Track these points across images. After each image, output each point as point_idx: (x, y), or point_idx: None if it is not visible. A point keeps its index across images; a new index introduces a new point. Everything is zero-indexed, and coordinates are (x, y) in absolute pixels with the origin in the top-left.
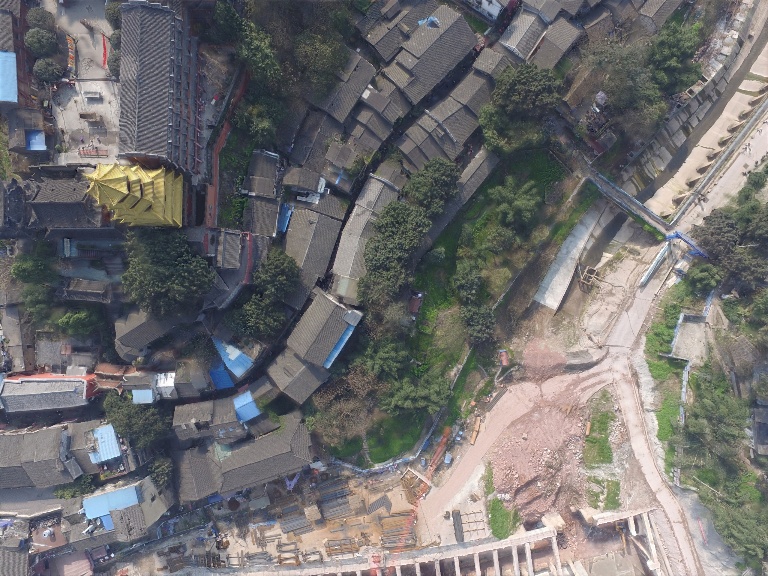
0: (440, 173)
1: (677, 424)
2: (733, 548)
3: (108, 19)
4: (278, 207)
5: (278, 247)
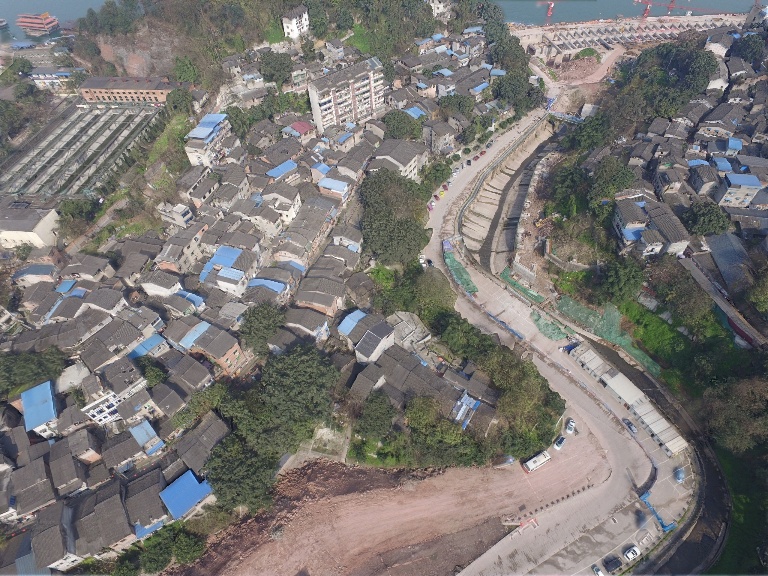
0: None
1: None
2: None
3: None
4: (767, 69)
5: (756, 67)
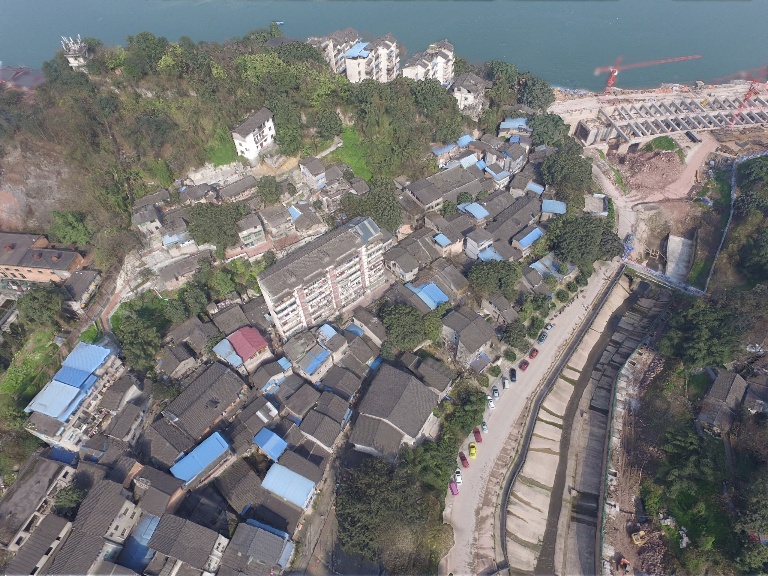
0: None
1: None
2: None
3: None
4: None
5: None
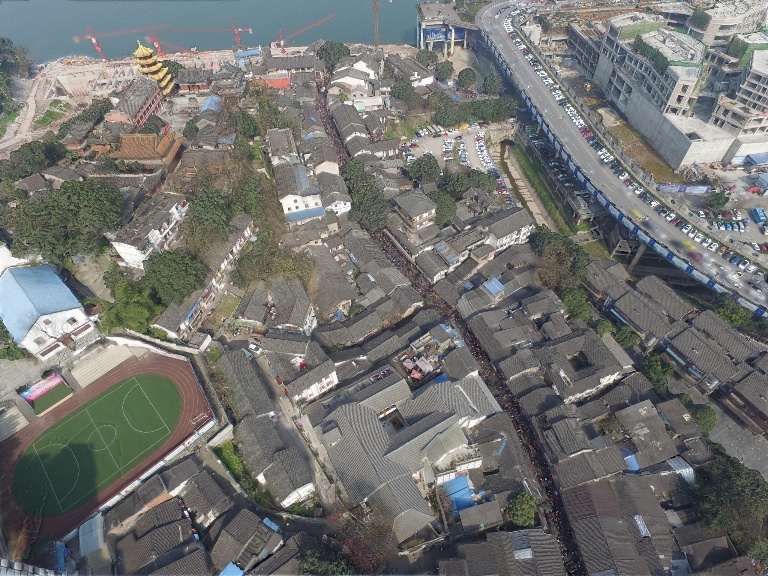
0: None
1: (5, 114)
2: (7, 76)
3: None
4: None
5: None
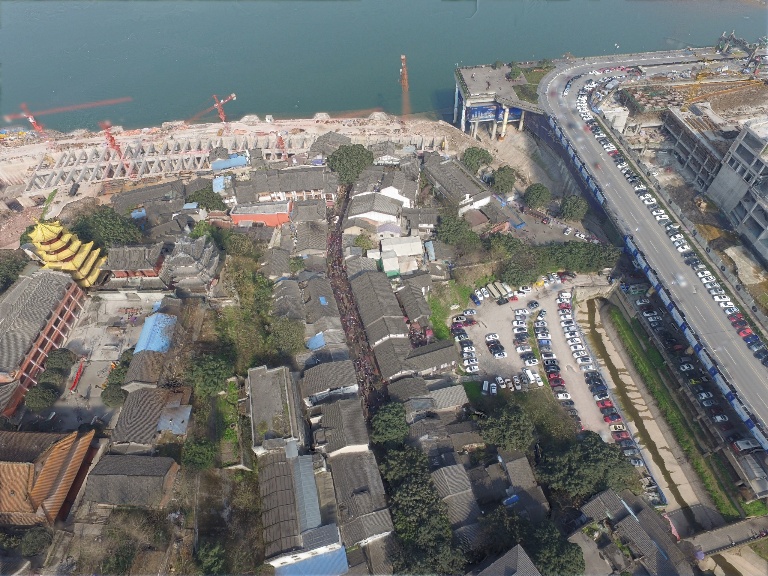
0: None
1: None
2: None
3: (44, 388)
4: None
5: None
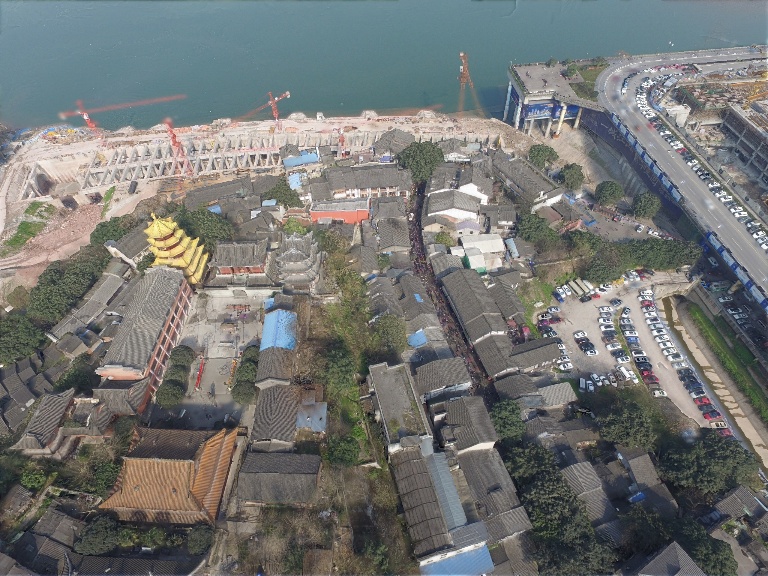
0: (3, 342)
1: None
2: None
3: (174, 385)
4: None
5: None
